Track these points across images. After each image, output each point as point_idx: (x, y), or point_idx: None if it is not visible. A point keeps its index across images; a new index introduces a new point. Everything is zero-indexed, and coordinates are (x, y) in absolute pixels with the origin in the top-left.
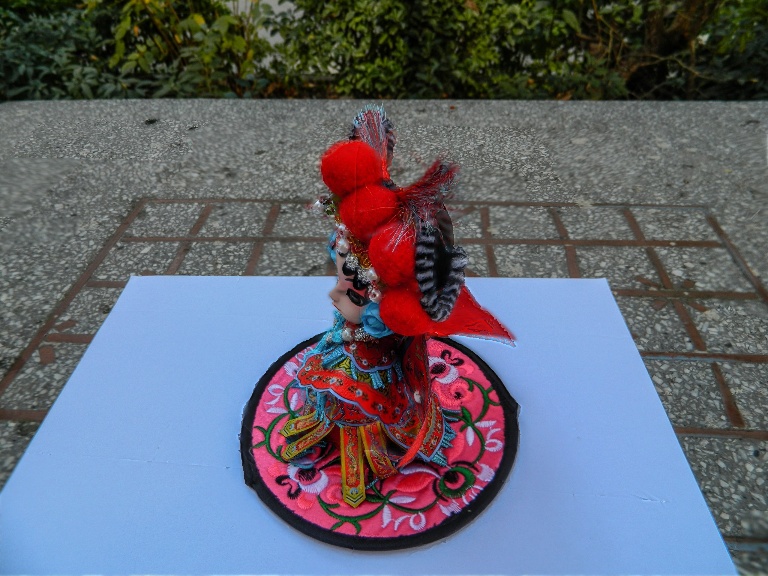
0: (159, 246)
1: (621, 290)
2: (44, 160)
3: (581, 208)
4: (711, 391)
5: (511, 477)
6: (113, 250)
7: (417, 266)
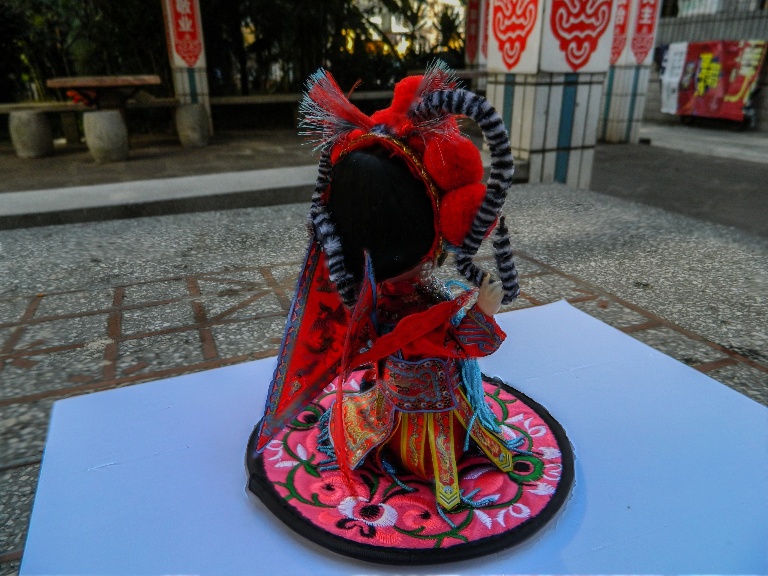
0: None
1: None
2: None
3: None
4: None
5: None
6: None
7: None
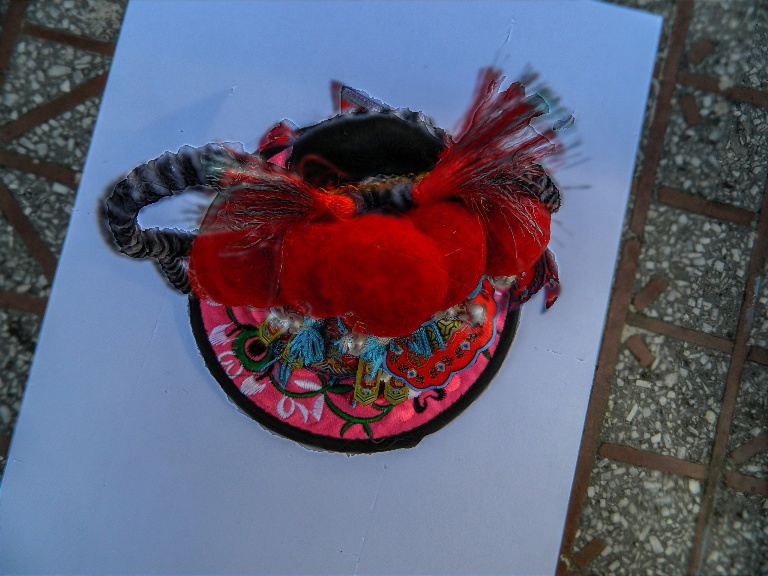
0: None
1: None
2: None
3: None
4: None
5: None
6: None
7: None
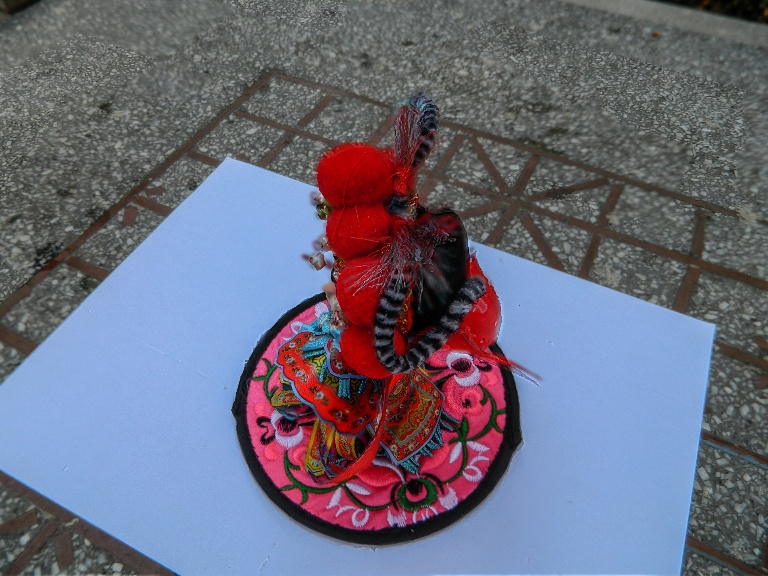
0: (265, 130)
1: (726, 347)
2: (205, 0)
3: (740, 221)
4: (762, 514)
5: (474, 513)
6: (224, 122)
7: (376, 319)
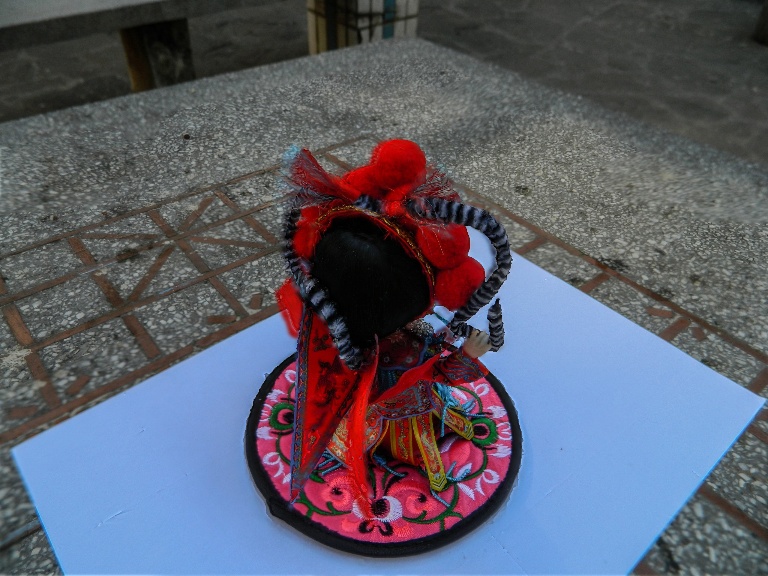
0: None
1: None
2: None
3: None
4: None
5: None
6: None
7: None
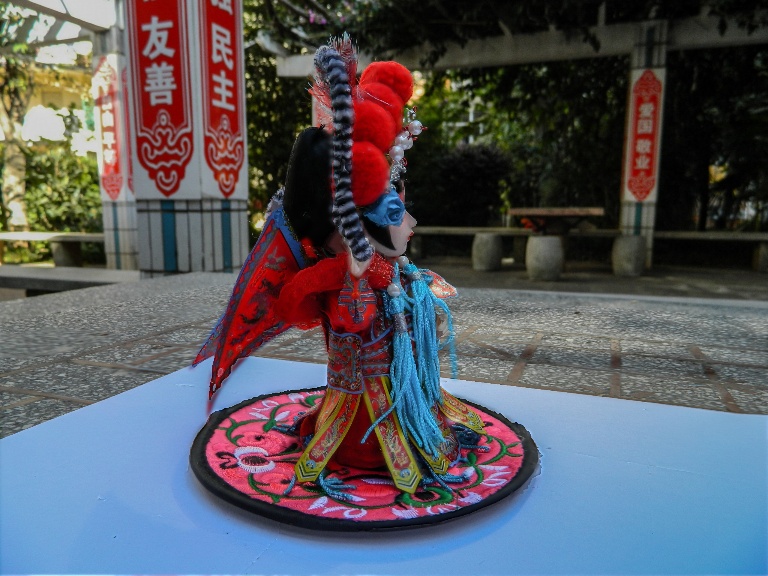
0: None
1: None
2: None
3: None
4: (3, 413)
5: None
6: None
7: None
